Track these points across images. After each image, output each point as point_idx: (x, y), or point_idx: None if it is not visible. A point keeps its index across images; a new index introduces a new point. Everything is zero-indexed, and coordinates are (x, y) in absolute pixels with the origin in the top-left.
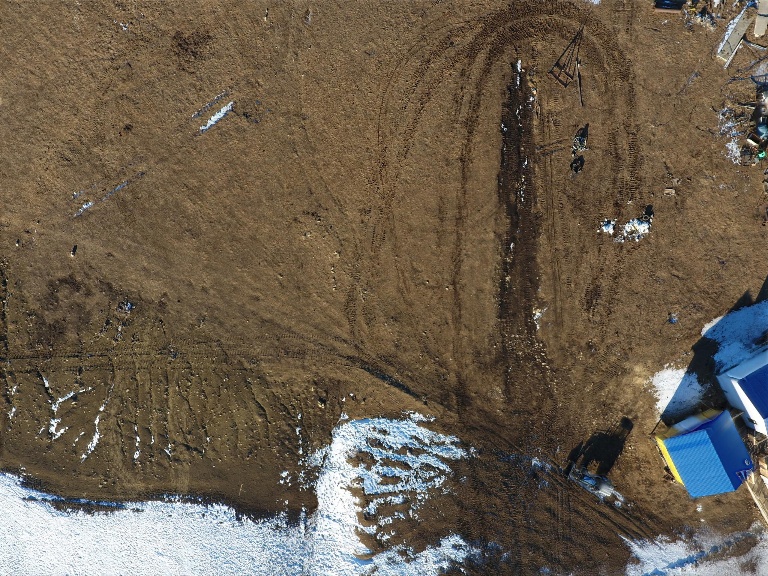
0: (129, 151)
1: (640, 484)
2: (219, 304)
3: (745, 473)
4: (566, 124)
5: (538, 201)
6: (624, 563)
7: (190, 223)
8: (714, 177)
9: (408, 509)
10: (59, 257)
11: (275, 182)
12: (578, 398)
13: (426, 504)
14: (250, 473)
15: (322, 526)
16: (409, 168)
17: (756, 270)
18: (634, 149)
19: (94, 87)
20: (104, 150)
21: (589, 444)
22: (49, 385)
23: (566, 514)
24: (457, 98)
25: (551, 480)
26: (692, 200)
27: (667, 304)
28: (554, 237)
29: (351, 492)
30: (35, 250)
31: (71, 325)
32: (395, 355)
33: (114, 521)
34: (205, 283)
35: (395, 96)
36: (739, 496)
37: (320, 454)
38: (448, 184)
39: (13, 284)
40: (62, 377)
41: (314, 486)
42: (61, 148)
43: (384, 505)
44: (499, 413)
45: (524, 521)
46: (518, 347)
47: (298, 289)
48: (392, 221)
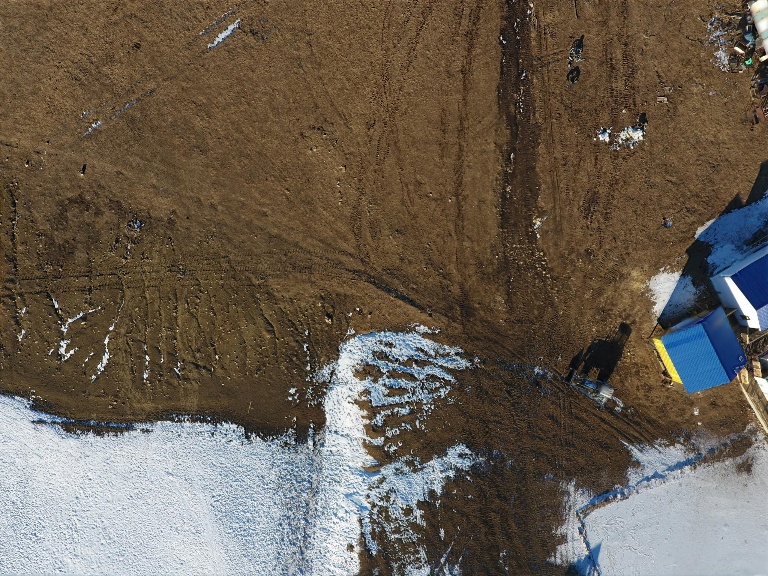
0: (138, 69)
1: (639, 389)
2: (227, 220)
3: (739, 374)
4: (562, 36)
5: (536, 111)
6: (625, 467)
7: (198, 140)
8: (704, 85)
9: (415, 420)
10: (68, 176)
11: (281, 97)
12: (578, 305)
13: (432, 414)
14: (259, 390)
15: (330, 442)
16: (412, 81)
17: (745, 173)
18: (627, 59)
19: (103, 7)
20: (113, 69)
21: (589, 351)
22: (58, 306)
23: (568, 421)
24: (457, 12)
25: (553, 388)
26: (683, 107)
27: (662, 209)
28: (552, 146)
29: (359, 405)
30: (44, 170)
31: (81, 244)
32: (400, 268)
33: (124, 442)
34: (213, 199)
35: (397, 10)
36: (734, 399)
37: (328, 370)
38: (450, 96)
39: (23, 205)
40: (72, 297)
41: (322, 402)
42: (70, 68)
43: (391, 416)
44: (502, 323)
45: (528, 428)
46: (519, 257)
47: (305, 204)
48: (396, 134)
